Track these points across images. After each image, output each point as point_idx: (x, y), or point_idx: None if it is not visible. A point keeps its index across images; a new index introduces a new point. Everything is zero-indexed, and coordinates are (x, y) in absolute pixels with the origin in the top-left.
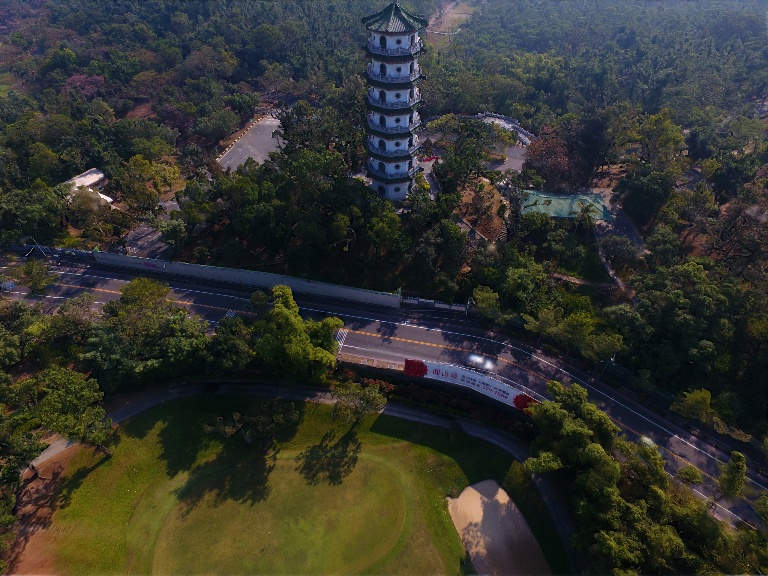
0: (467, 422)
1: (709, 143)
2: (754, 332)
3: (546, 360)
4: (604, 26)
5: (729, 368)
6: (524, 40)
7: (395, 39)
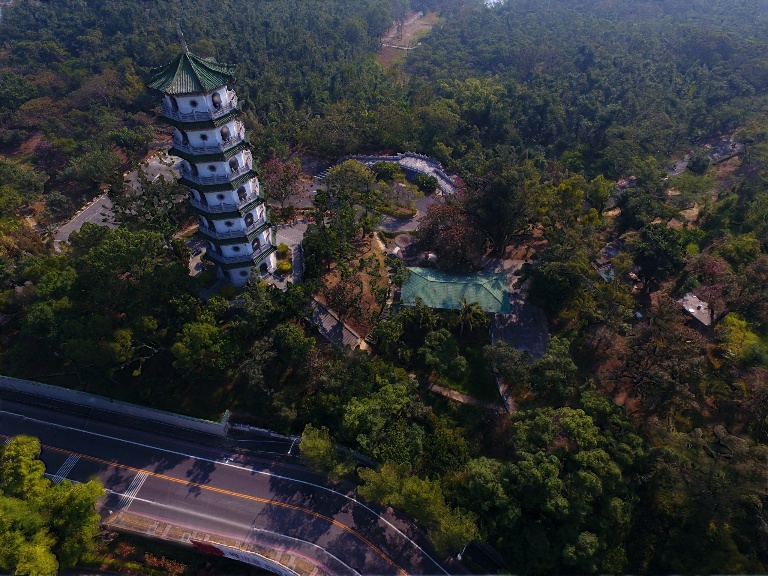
0: None
1: (641, 210)
2: (665, 504)
3: (396, 525)
4: (568, 43)
5: (625, 564)
6: (480, 58)
7: (187, 100)
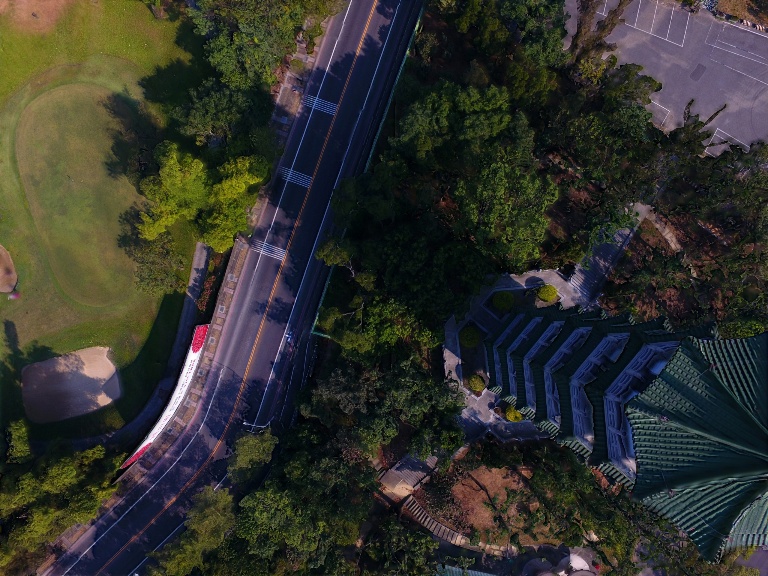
0: (172, 384)
1: None
2: None
3: None
4: None
5: None
6: None
7: None
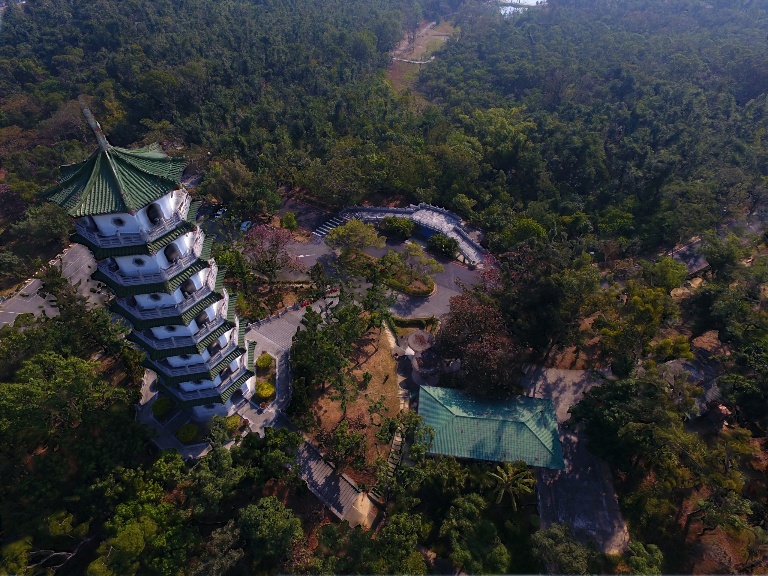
0: None
1: (731, 318)
2: None
3: None
4: (598, 62)
5: None
6: None
7: (107, 218)
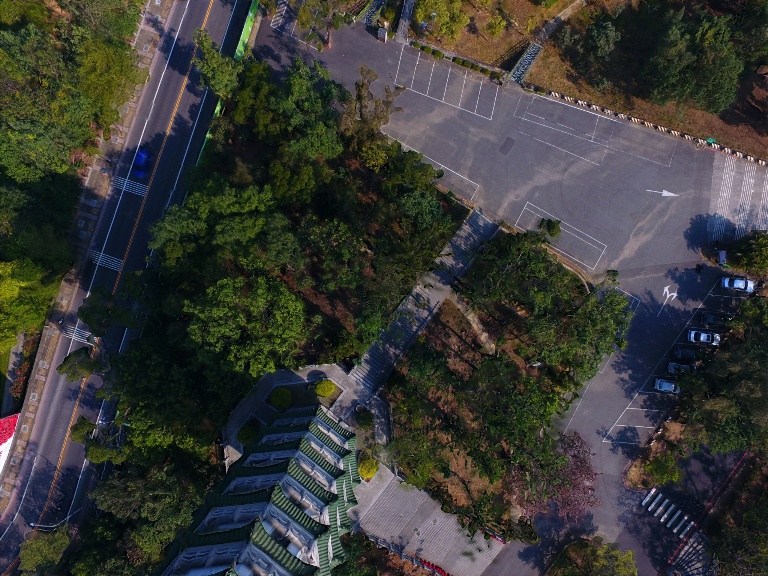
0: None
1: None
2: None
3: None
4: None
5: None
6: None
7: None
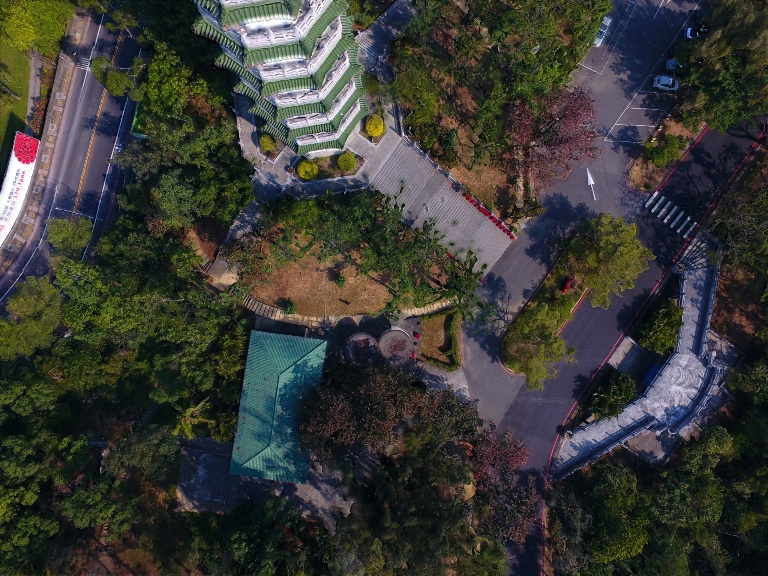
0: None
1: None
2: None
3: None
4: None
5: None
6: None
7: None
